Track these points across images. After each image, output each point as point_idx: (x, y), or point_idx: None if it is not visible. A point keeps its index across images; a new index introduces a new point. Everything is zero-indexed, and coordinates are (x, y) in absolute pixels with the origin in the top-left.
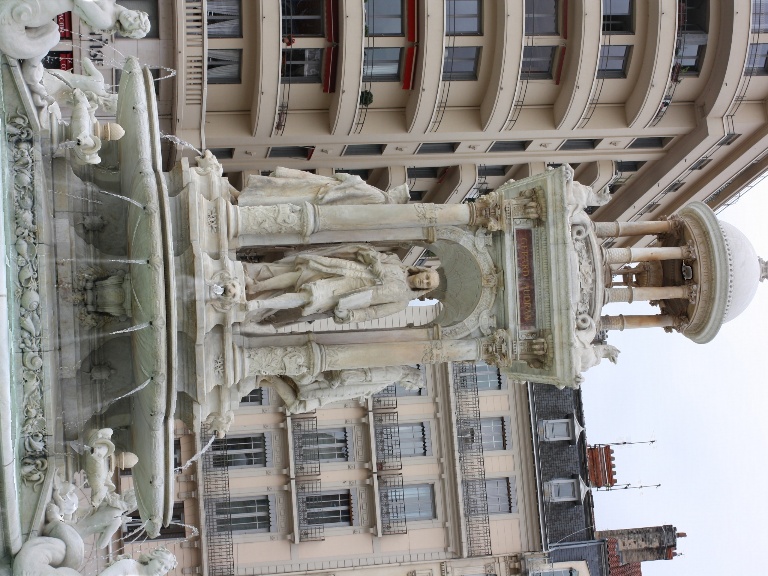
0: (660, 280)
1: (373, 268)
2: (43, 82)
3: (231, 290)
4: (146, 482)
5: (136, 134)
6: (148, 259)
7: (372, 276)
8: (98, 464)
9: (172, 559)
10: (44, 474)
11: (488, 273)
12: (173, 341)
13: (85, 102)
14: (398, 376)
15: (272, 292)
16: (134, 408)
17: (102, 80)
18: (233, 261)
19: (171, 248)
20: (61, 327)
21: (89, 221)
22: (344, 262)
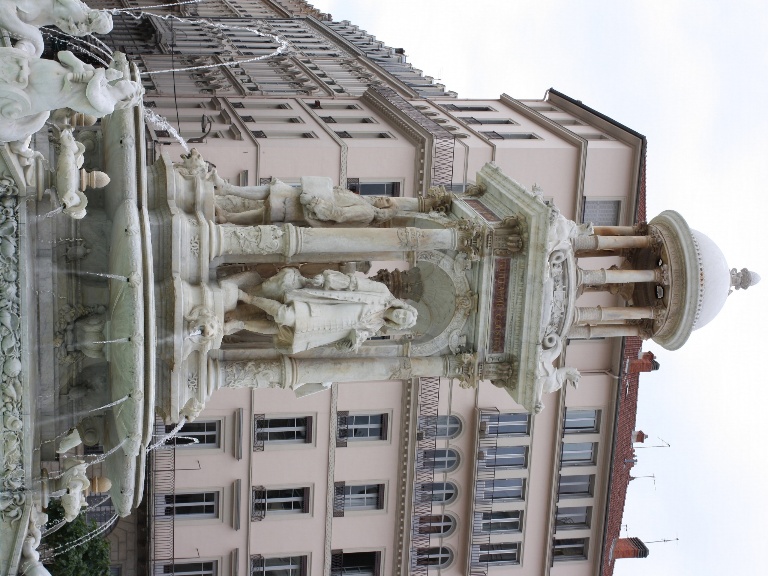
0: (629, 265)
1: None
2: None
3: None
4: (122, 245)
5: None
6: None
7: None
8: None
9: None
10: None
11: None
12: (137, 80)
13: None
14: (385, 288)
15: None
16: None
17: None
18: None
19: None
20: None
21: None
22: None
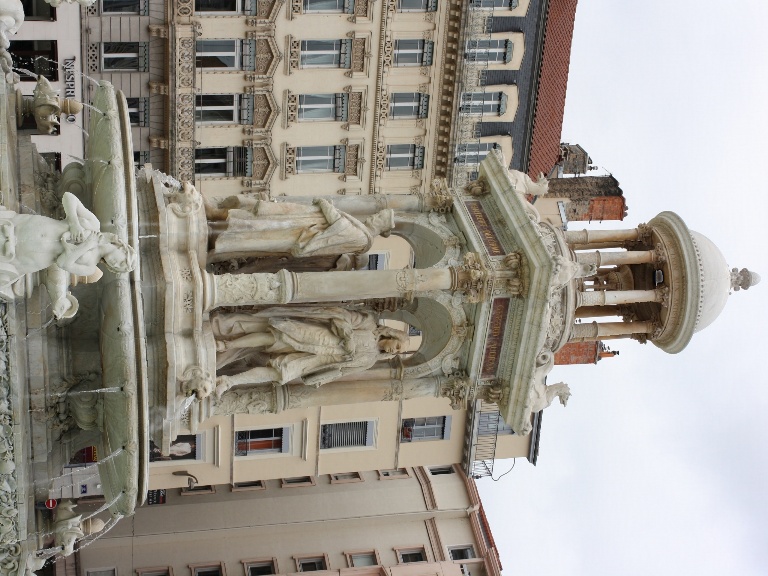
0: None
1: (345, 346)
2: None
3: (202, 398)
4: None
5: None
6: (124, 445)
7: (343, 352)
8: None
9: None
10: (18, 561)
11: (459, 324)
12: (144, 493)
13: None
14: None
15: None
16: None
17: None
18: (206, 349)
19: (147, 425)
20: (34, 441)
21: (62, 322)
22: (317, 336)
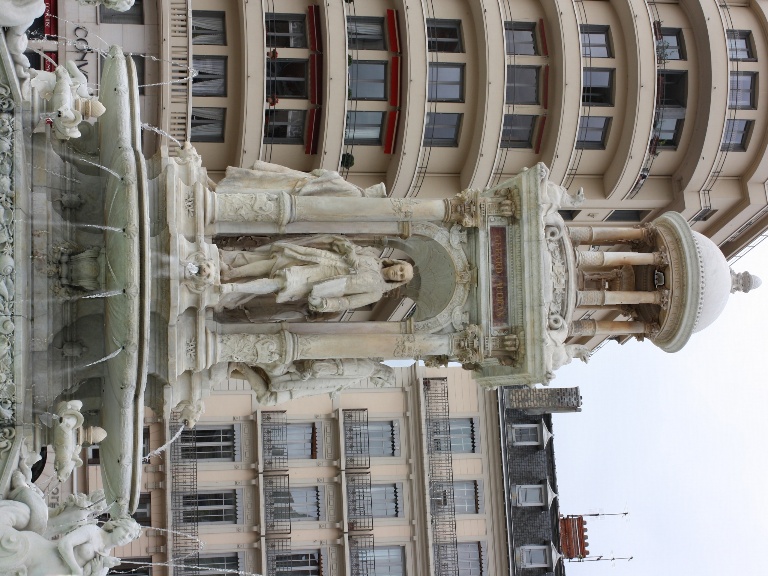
0: (632, 287)
1: (348, 257)
2: None
3: (206, 269)
4: (114, 462)
5: (117, 114)
6: (124, 227)
7: (346, 265)
8: (66, 435)
9: (137, 527)
10: (11, 442)
11: (462, 270)
12: (146, 311)
13: (67, 79)
14: (370, 371)
15: (246, 279)
16: (104, 389)
17: (85, 82)
18: (209, 244)
19: (147, 219)
20: (34, 298)
21: (67, 198)
22: (319, 251)
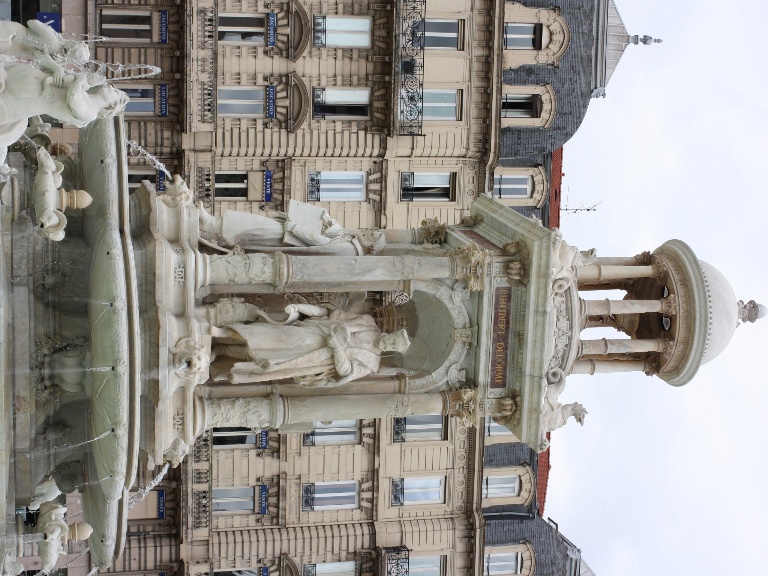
0: None
1: None
2: (4, 123)
3: None
4: None
5: None
6: None
7: None
8: None
9: None
10: None
11: None
12: None
13: None
14: None
15: None
16: None
17: None
18: None
19: None
20: None
21: None
22: None
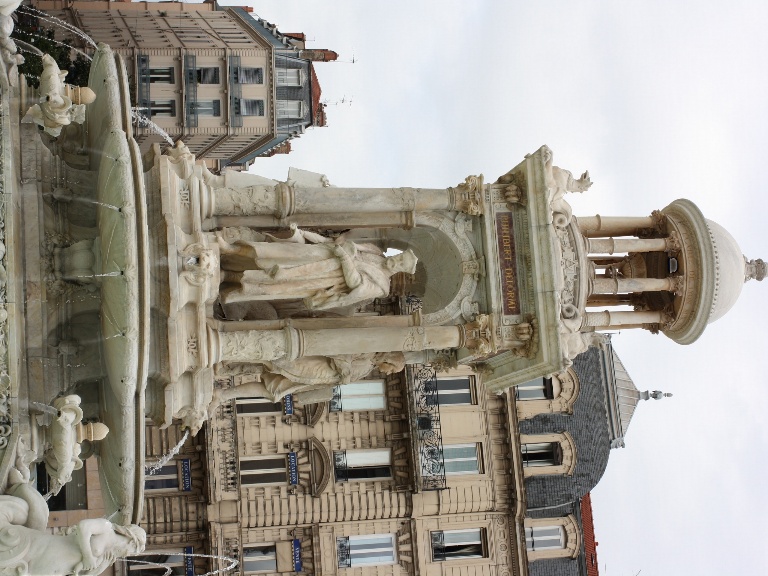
0: None
1: (341, 380)
2: None
3: None
4: None
5: None
6: None
7: (338, 380)
8: None
9: None
10: None
11: None
12: None
13: None
14: None
15: None
16: None
17: None
18: (204, 393)
19: None
20: None
21: None
22: (315, 371)
